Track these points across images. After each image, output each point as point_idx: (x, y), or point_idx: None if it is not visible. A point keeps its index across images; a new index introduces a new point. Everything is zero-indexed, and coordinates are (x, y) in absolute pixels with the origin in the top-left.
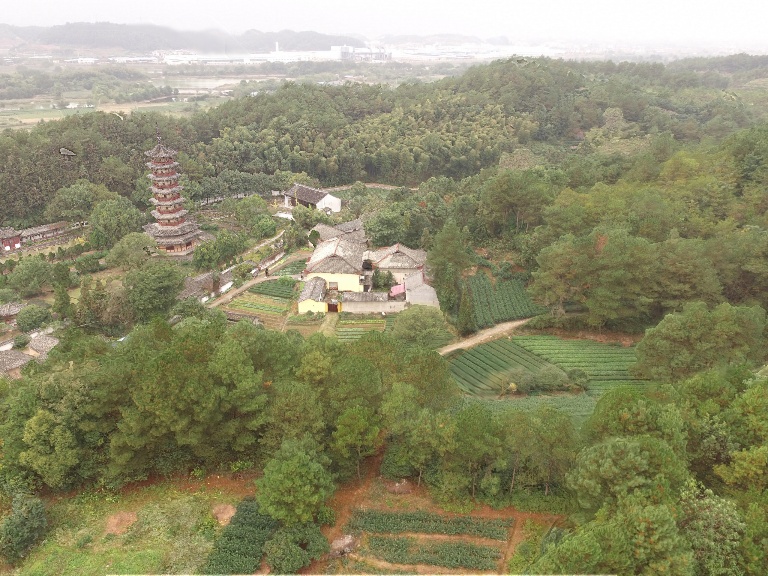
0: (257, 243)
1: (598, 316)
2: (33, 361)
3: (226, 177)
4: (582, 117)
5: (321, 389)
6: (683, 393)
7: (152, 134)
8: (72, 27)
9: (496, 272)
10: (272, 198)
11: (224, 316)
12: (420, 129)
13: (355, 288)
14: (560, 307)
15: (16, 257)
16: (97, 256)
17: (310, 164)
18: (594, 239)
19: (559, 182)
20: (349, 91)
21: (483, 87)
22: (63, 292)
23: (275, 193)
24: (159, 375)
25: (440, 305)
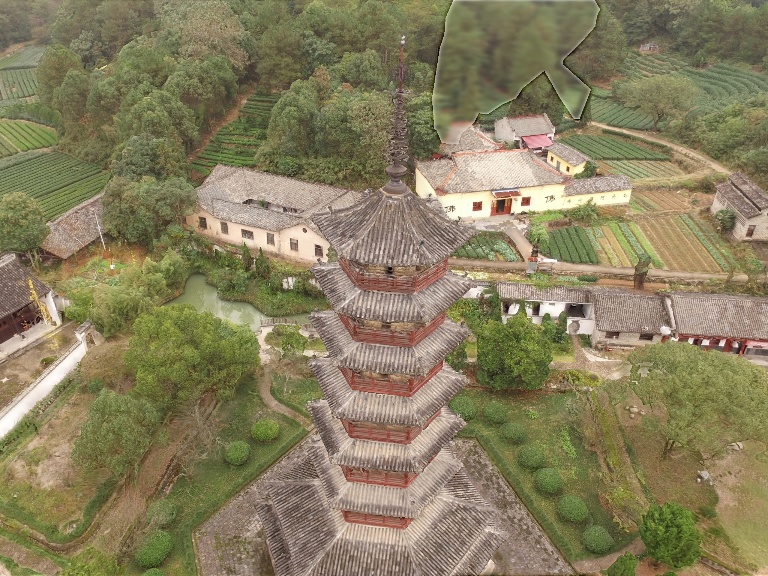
0: None
1: None
2: None
3: None
4: None
5: None
6: (725, 13)
7: None
8: None
9: None
10: None
11: None
12: None
13: None
14: None
15: None
16: None
17: None
18: None
19: None
20: None
21: None
22: None
23: None
24: None
25: None
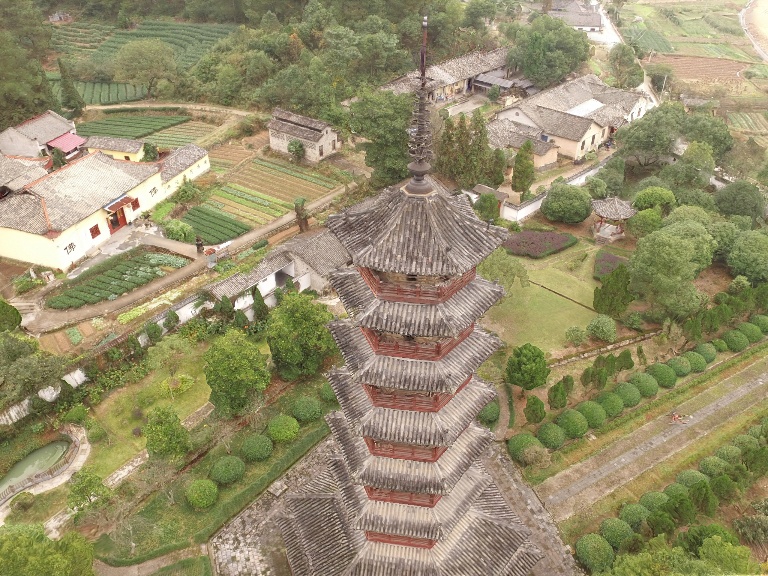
0: None
1: None
2: None
3: None
4: None
5: None
6: None
7: None
8: None
9: None
10: None
11: None
12: None
13: None
14: None
15: None
16: None
17: None
18: None
19: None
20: None
21: None
22: None
23: None
24: None
25: None
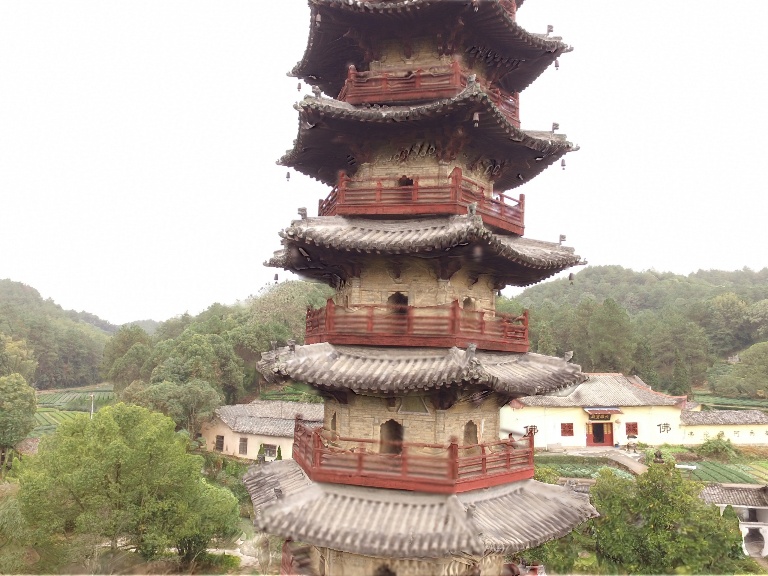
0: None
1: None
2: None
3: None
4: None
5: None
6: None
7: None
8: None
9: None
10: None
11: None
12: None
13: None
14: None
15: None
16: None
17: None
18: None
19: None
20: None
21: None
22: None
23: None
24: None
25: (655, 390)
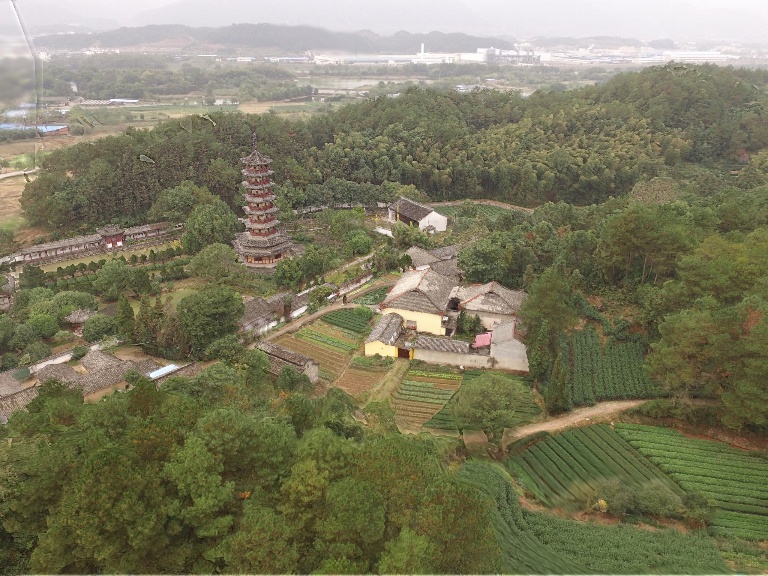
0: (348, 261)
1: (737, 416)
2: None
3: (332, 185)
4: (749, 137)
5: (308, 516)
6: None
7: (264, 137)
8: (212, 28)
9: (608, 330)
10: (377, 210)
11: (265, 360)
12: (548, 143)
13: (436, 330)
14: (685, 395)
15: (111, 257)
16: (187, 261)
17: (421, 176)
18: (742, 313)
19: (705, 223)
20: (476, 98)
21: (629, 97)
22: (126, 305)
23: (381, 205)
24: (89, 481)
25: (529, 368)
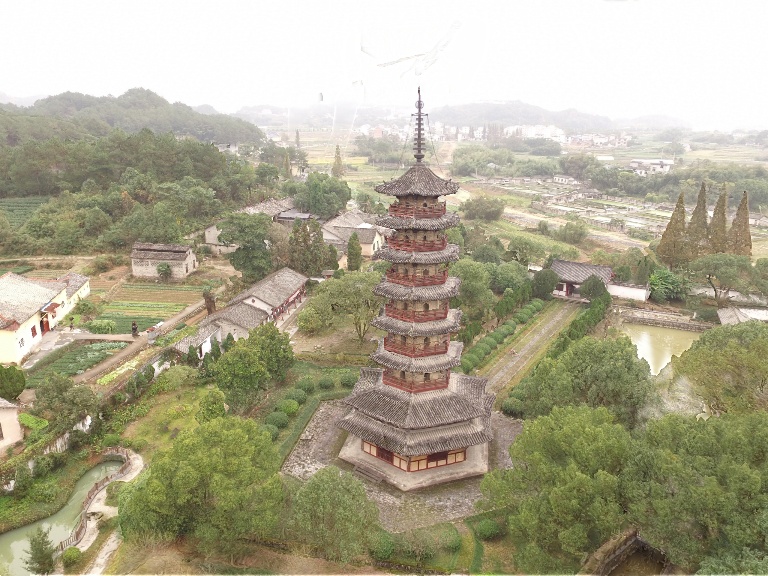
0: None
1: None
2: (212, 144)
3: None
4: None
5: None
6: None
7: None
8: None
9: None
10: None
11: None
12: None
13: None
14: None
15: None
16: None
17: None
18: None
19: None
20: None
21: None
22: None
23: None
24: None
25: None
